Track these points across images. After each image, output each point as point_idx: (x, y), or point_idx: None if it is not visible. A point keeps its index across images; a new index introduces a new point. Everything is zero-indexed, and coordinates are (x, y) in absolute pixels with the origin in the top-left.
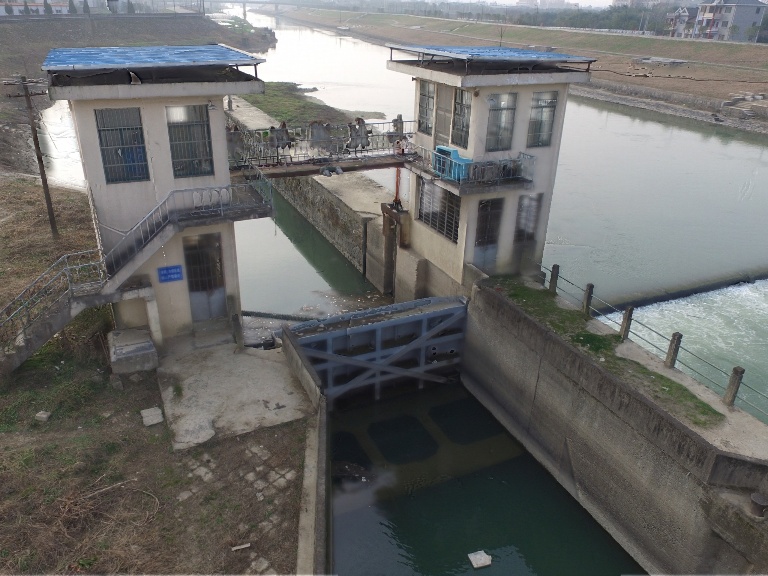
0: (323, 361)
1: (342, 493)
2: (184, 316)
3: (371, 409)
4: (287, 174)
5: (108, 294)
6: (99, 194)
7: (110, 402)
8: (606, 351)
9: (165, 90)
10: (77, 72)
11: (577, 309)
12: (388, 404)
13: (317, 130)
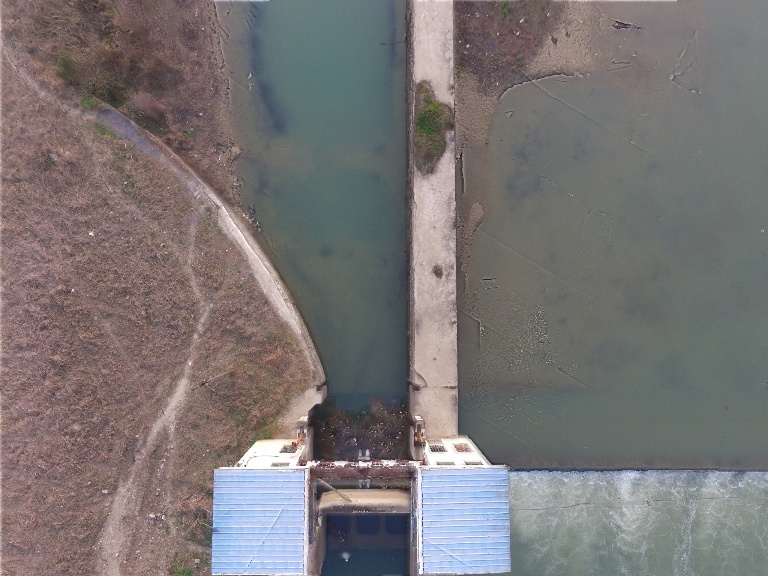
0: None
1: (334, 541)
2: None
3: None
4: None
5: None
6: None
7: None
8: None
9: None
10: None
11: None
12: None
13: None
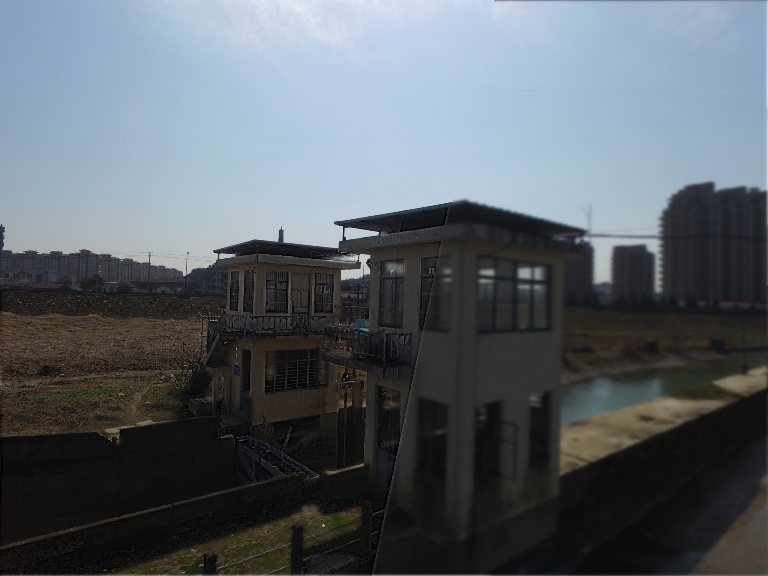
0: None
1: None
2: None
3: None
4: None
5: None
6: None
7: None
8: None
9: None
10: None
11: (311, 573)
12: None
13: None
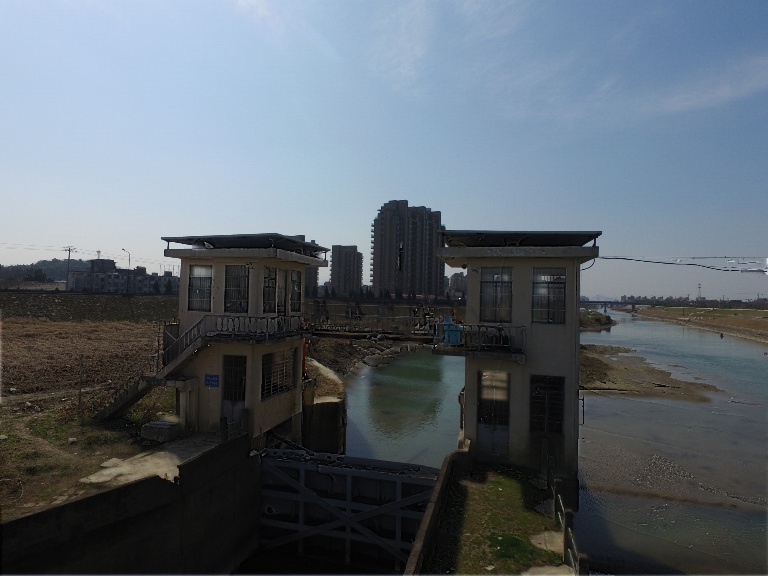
0: (295, 491)
1: None
2: (216, 417)
3: (340, 570)
4: (343, 336)
5: (159, 379)
6: (183, 316)
7: (111, 448)
8: (512, 562)
9: (219, 252)
10: (179, 241)
11: None
12: (357, 572)
13: (382, 309)
